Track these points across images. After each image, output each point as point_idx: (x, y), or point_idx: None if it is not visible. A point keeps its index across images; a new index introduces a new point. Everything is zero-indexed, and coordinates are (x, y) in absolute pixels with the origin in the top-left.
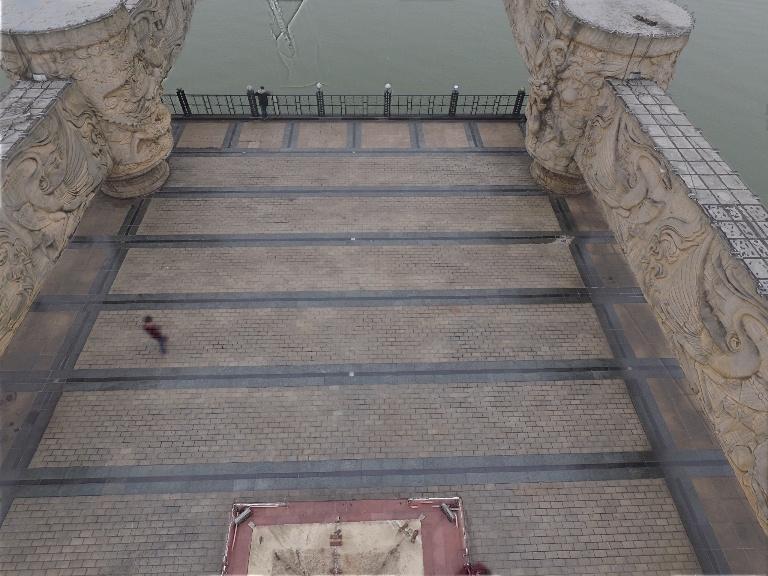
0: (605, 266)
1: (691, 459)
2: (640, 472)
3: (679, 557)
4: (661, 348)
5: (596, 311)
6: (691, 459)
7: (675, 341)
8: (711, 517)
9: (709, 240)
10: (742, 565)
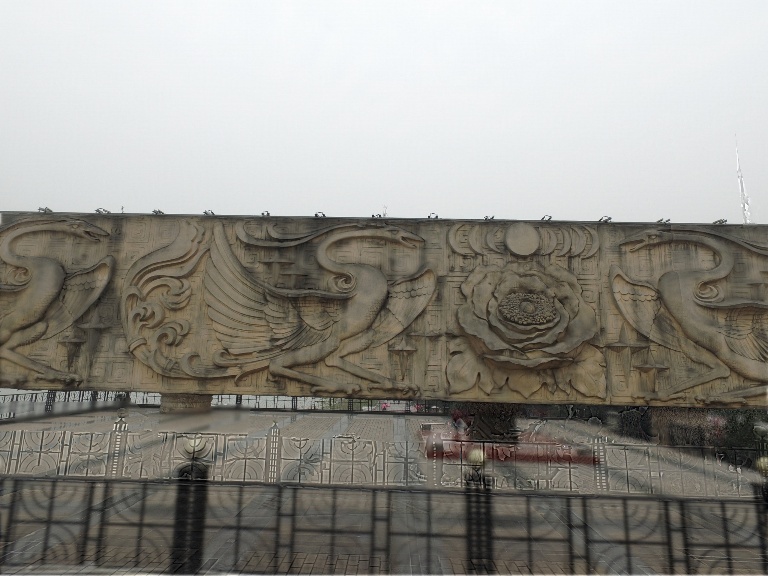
0: (7, 517)
1: (405, 532)
2: (430, 574)
3: (571, 575)
4: (218, 513)
5: (81, 544)
6: (405, 532)
7: (280, 370)
8: (492, 539)
9: (221, 228)
10: (550, 537)
